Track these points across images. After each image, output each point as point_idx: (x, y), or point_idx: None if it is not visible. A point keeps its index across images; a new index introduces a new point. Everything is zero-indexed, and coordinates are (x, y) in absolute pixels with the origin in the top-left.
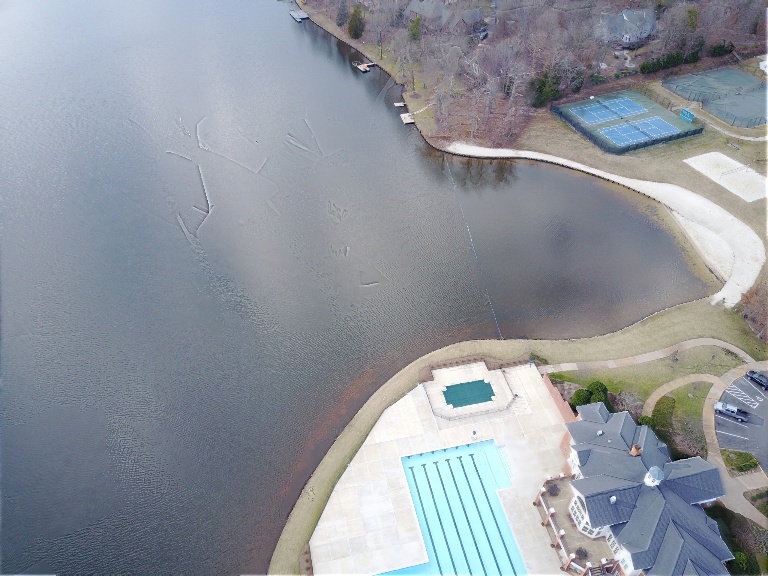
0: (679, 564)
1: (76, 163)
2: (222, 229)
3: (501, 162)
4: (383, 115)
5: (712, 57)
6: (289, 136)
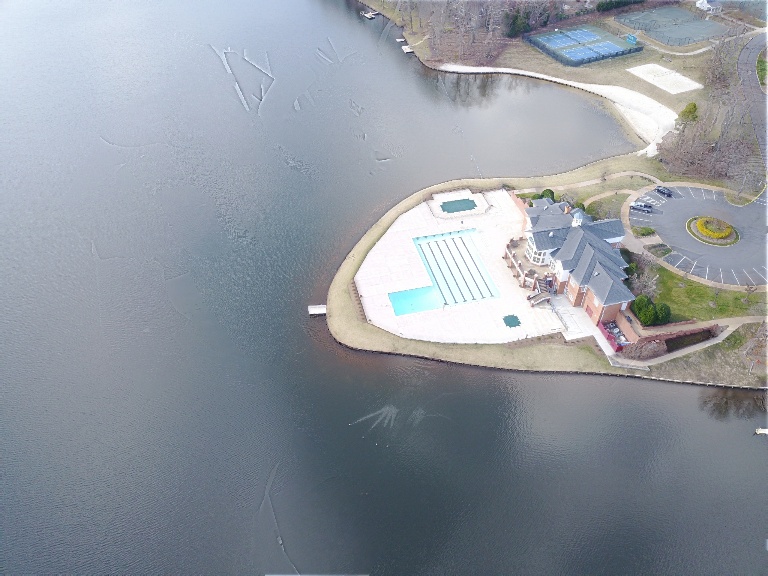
0: (591, 264)
1: (179, 48)
2: (276, 107)
3: (483, 80)
4: None
5: None
6: (318, 50)
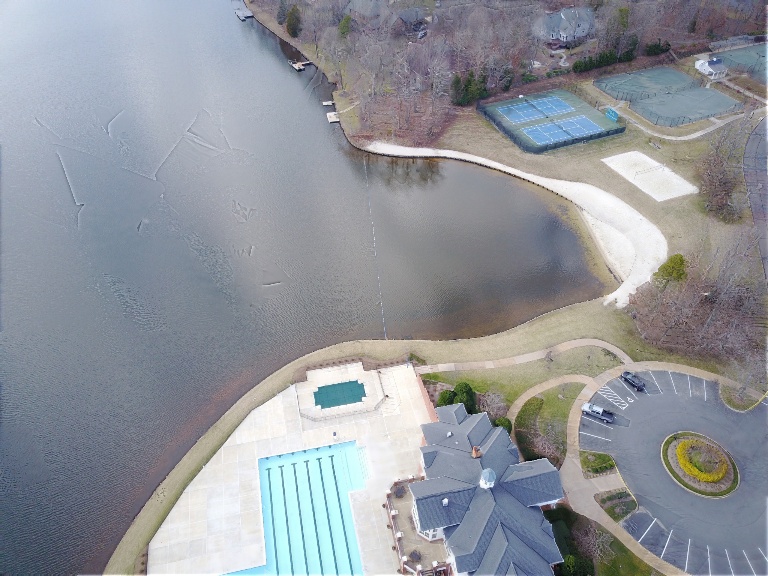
0: (501, 567)
1: None
2: (108, 228)
3: (425, 161)
4: (309, 114)
5: (648, 56)
6: (193, 135)
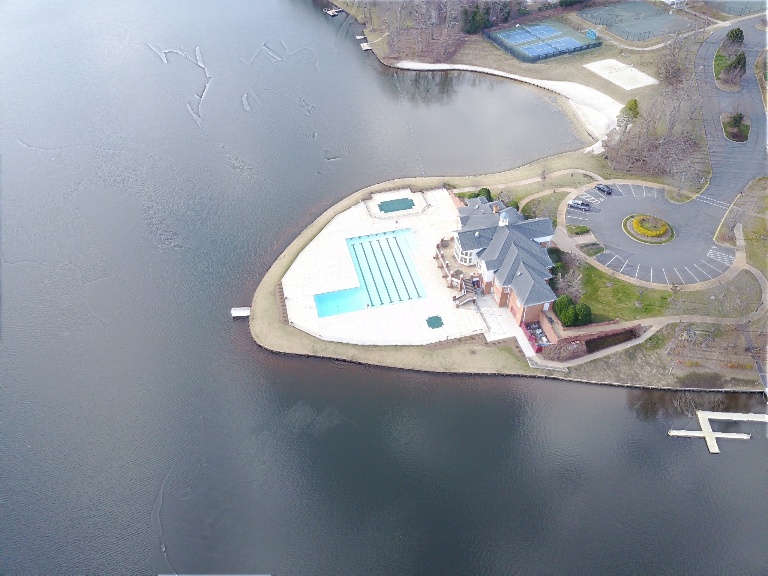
0: (515, 264)
1: (112, 49)
2: (218, 107)
3: (442, 77)
4: (346, 44)
5: None
6: (267, 49)
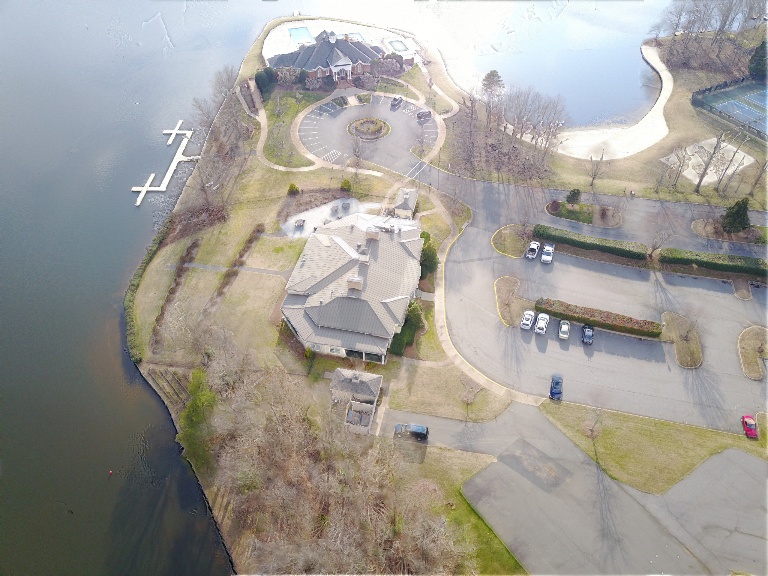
0: None
1: None
2: None
3: None
4: None
5: None
6: None
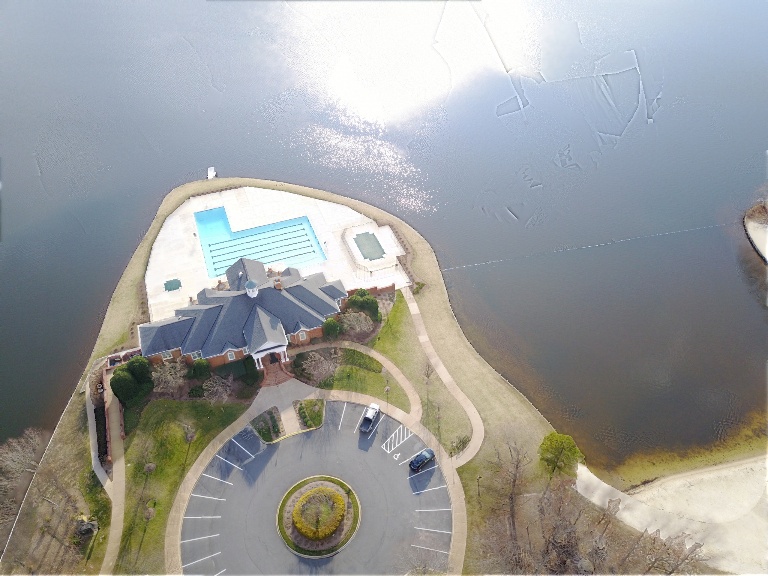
0: (194, 312)
1: None
2: (467, 83)
3: None
4: None
5: None
6: (605, 82)
